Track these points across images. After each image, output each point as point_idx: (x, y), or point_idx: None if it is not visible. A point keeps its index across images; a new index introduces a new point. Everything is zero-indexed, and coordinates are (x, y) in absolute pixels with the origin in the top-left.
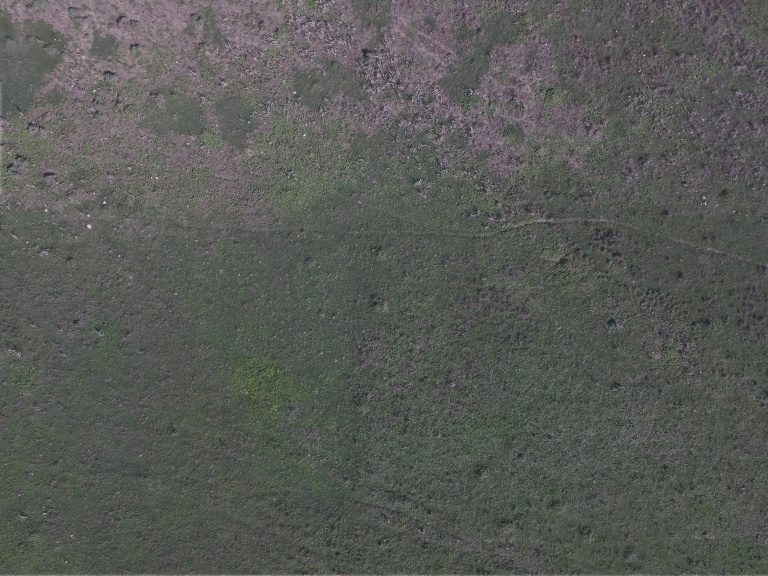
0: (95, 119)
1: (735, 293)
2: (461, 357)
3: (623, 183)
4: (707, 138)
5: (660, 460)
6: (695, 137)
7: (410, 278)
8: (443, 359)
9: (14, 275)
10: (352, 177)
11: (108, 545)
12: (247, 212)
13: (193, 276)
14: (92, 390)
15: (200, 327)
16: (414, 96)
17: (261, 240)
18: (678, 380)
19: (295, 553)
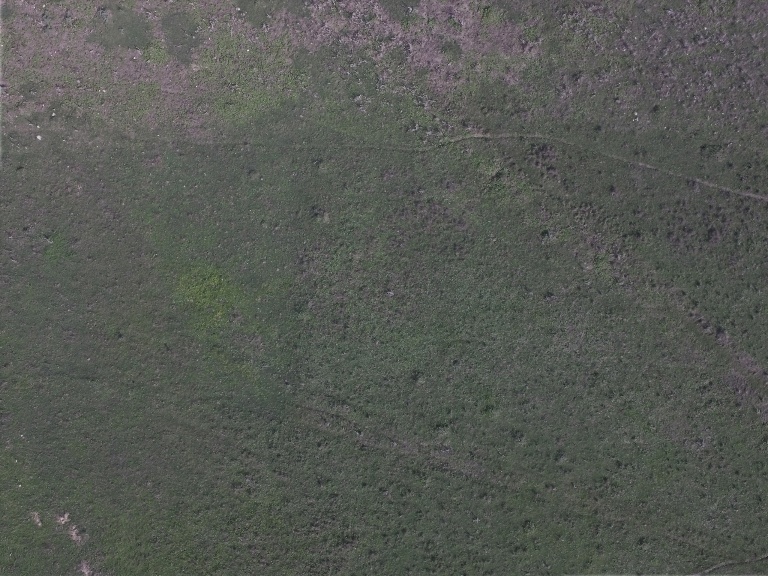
0: (44, 33)
1: (665, 207)
2: (399, 267)
3: (558, 99)
4: (639, 56)
5: (591, 367)
6: (628, 55)
7: (350, 190)
8: (382, 269)
9: None
10: (294, 92)
11: (57, 445)
12: (192, 125)
13: (140, 187)
14: (41, 295)
15: (147, 236)
16: (354, 13)
17: (206, 153)
18: (609, 290)
19: (238, 455)
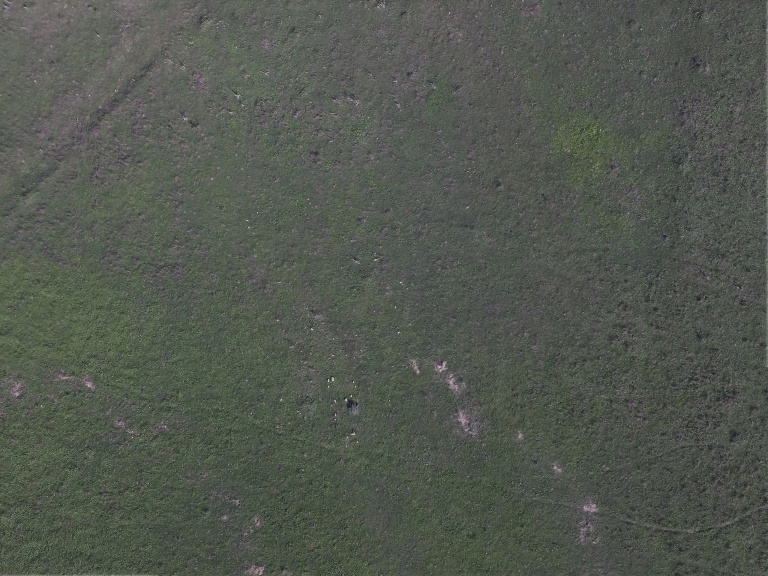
0: None
1: None
2: None
3: None
4: None
5: None
6: None
7: (731, 41)
8: (762, 122)
9: (351, 27)
10: None
11: (435, 293)
12: None
13: (518, 36)
14: (423, 141)
15: (525, 85)
16: None
17: (585, 2)
18: None
19: (614, 307)
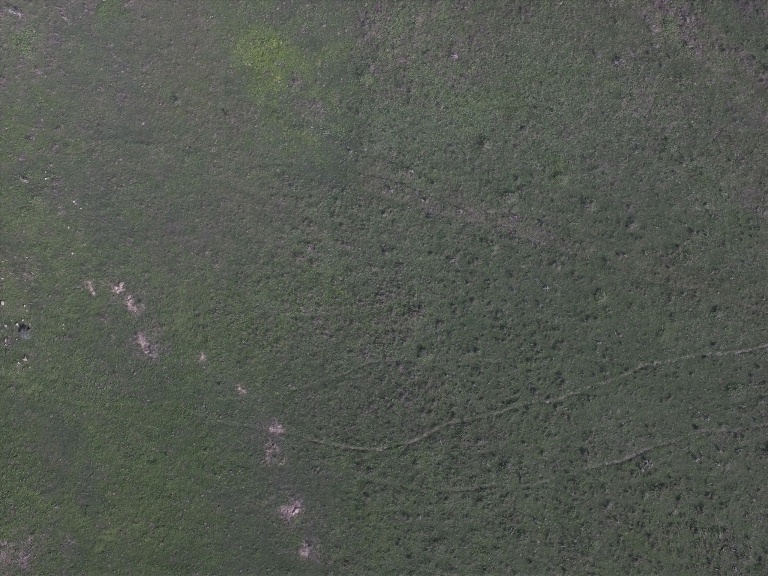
0: None
1: None
2: (463, 31)
3: None
4: None
5: (661, 132)
6: None
7: None
8: (446, 33)
9: None
10: None
11: (111, 212)
12: None
13: None
14: (94, 56)
15: None
16: None
17: None
18: (679, 53)
19: (299, 224)
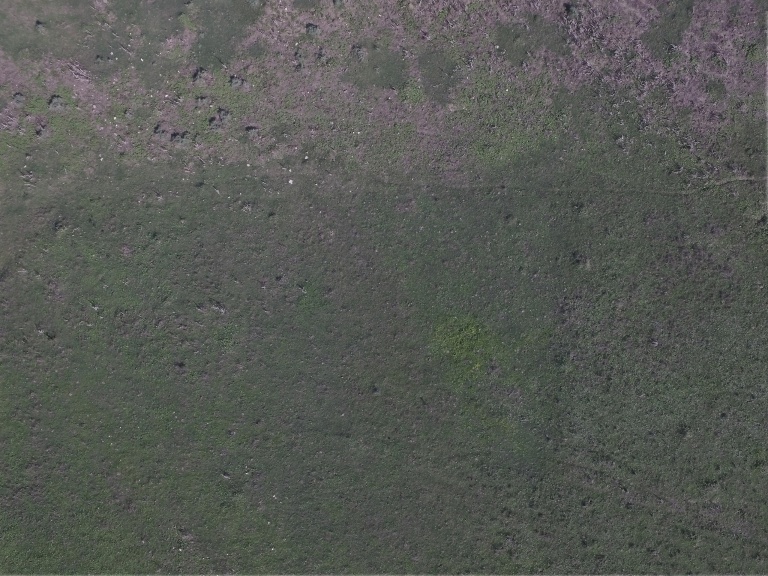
0: (297, 72)
1: None
2: (663, 316)
3: None
4: None
5: None
6: None
7: (612, 236)
8: (645, 318)
9: (216, 231)
10: (554, 133)
11: (310, 505)
12: (449, 168)
13: (393, 233)
14: (294, 348)
15: (401, 285)
16: (617, 51)
17: (461, 197)
18: None
19: (497, 514)
